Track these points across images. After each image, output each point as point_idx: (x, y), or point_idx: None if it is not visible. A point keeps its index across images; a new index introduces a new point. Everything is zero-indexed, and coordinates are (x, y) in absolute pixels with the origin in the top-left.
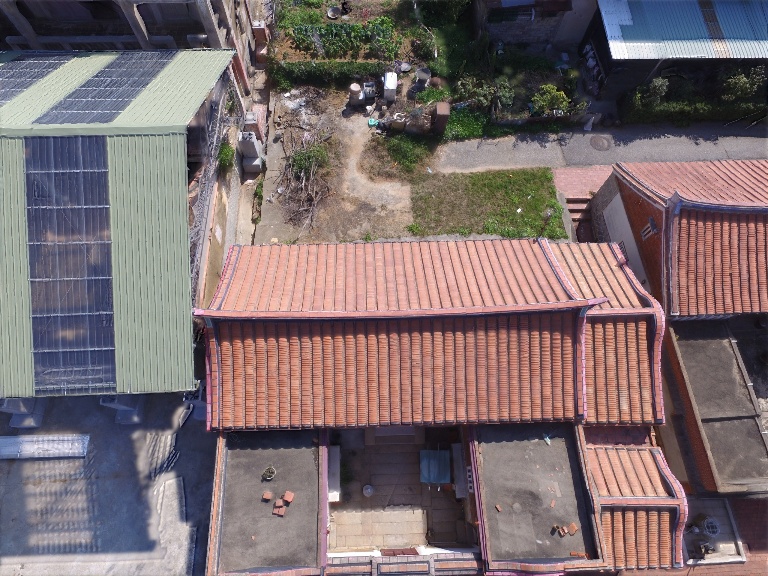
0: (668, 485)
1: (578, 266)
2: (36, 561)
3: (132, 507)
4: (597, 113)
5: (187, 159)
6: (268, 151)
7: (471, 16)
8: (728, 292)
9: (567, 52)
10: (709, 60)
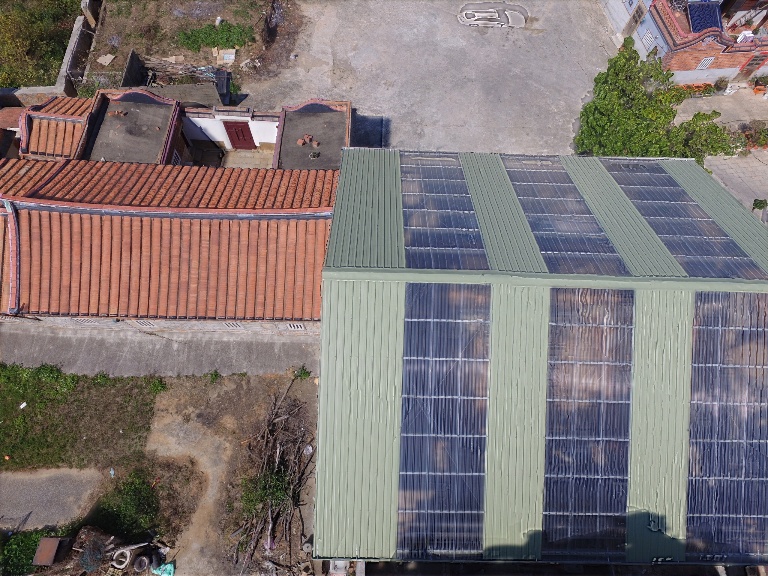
0: (28, 123)
1: None
2: None
3: None
4: None
5: None
6: None
7: None
8: None
9: None
10: None
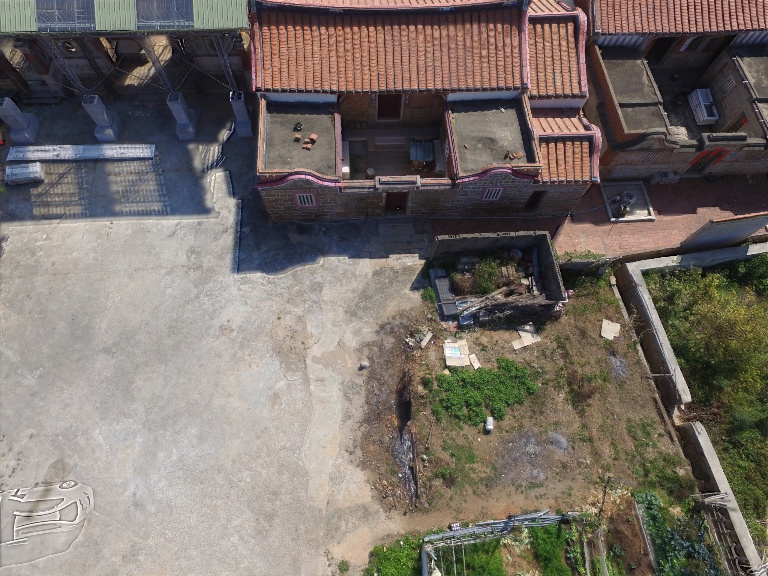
0: (588, 127)
1: None
2: (122, 219)
3: (191, 188)
4: None
5: None
6: None
7: None
8: (638, 17)
9: None
10: None
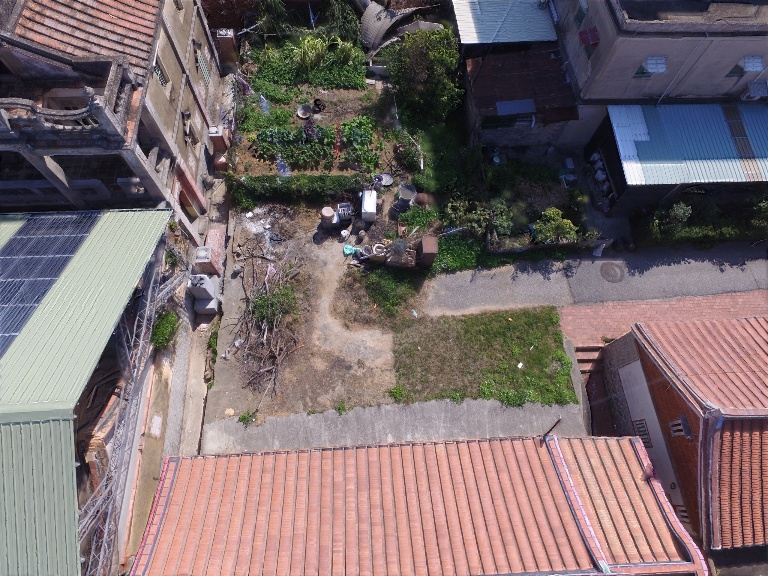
0: None
1: (595, 479)
2: None
3: None
4: (608, 239)
5: (75, 453)
6: (225, 290)
7: (462, 113)
8: None
9: (571, 155)
10: (738, 183)
